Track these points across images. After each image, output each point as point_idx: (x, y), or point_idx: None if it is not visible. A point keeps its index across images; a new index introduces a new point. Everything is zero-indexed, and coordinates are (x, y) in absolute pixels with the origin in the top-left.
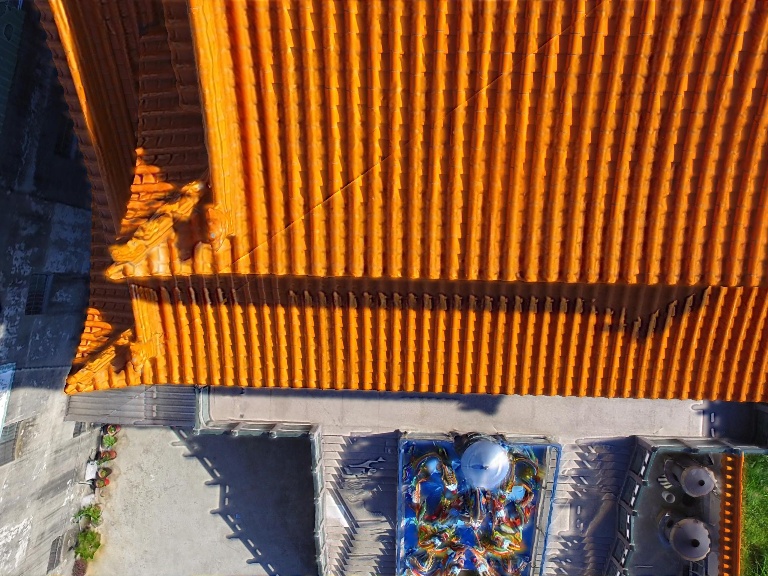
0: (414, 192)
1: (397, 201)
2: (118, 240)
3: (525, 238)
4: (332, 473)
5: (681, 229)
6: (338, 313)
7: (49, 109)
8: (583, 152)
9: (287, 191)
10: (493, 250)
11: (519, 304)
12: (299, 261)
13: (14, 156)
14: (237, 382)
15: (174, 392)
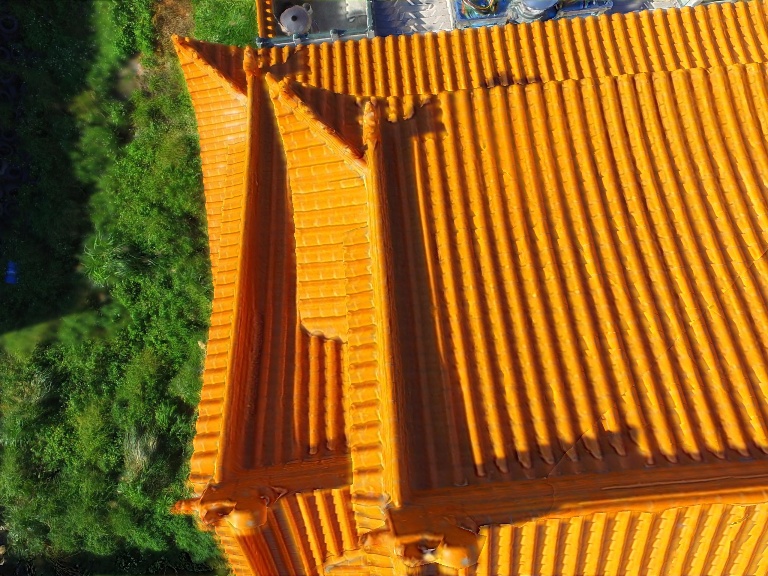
0: None
1: None
2: None
3: (713, 103)
4: None
5: (574, 126)
6: None
7: None
8: (688, 176)
9: None
10: (741, 89)
11: None
12: None
13: None
14: None
15: None
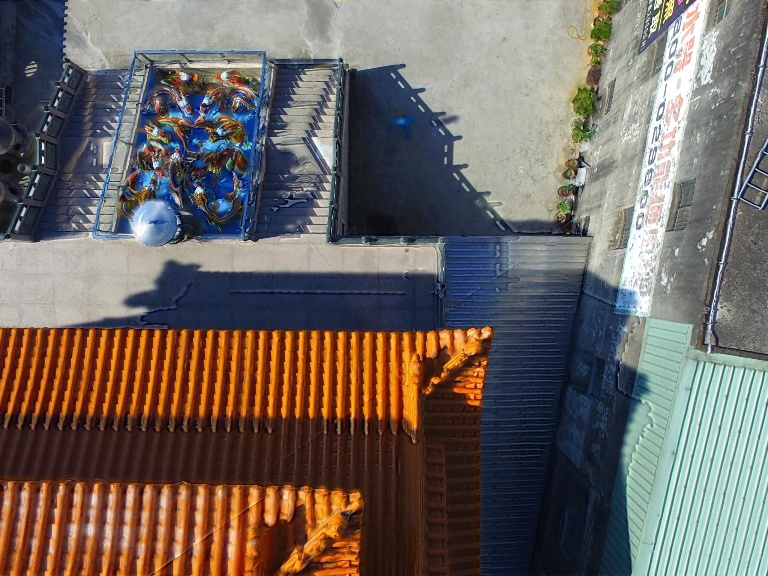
0: (89, 570)
1: (106, 561)
2: (358, 530)
3: None
4: (326, 192)
5: None
6: (231, 409)
7: (576, 568)
8: None
9: (206, 571)
10: (25, 513)
11: (62, 421)
12: (202, 501)
13: (598, 530)
14: (335, 336)
15: (479, 270)
